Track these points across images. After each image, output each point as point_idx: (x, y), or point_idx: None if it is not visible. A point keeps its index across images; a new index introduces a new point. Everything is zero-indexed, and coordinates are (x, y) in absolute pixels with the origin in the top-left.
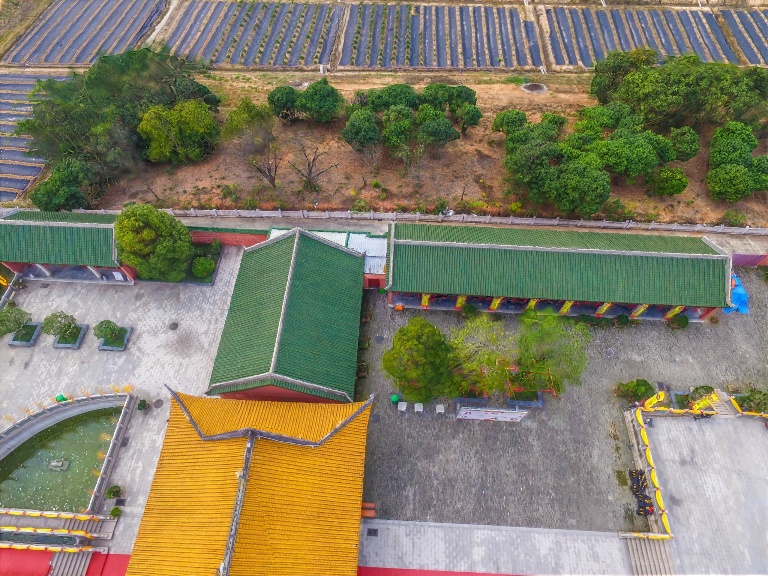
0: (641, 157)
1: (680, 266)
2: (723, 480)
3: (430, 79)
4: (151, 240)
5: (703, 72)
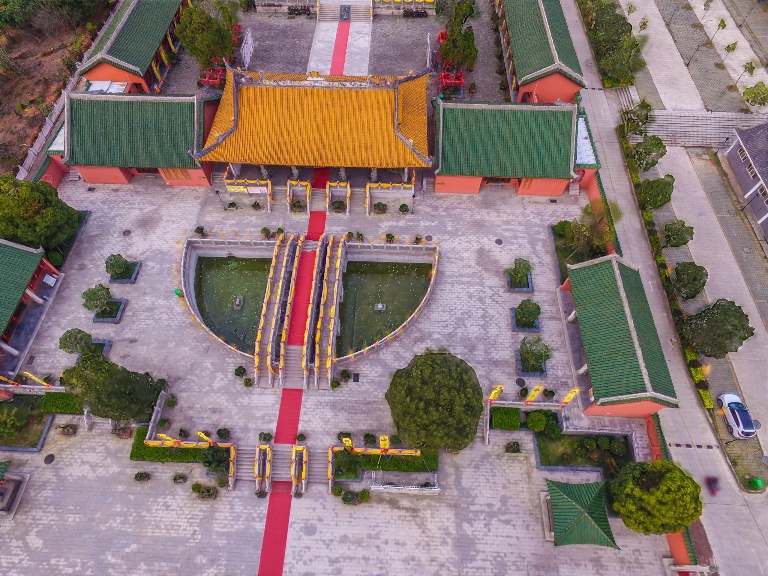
0: None
1: None
2: None
3: None
4: (32, 187)
5: None
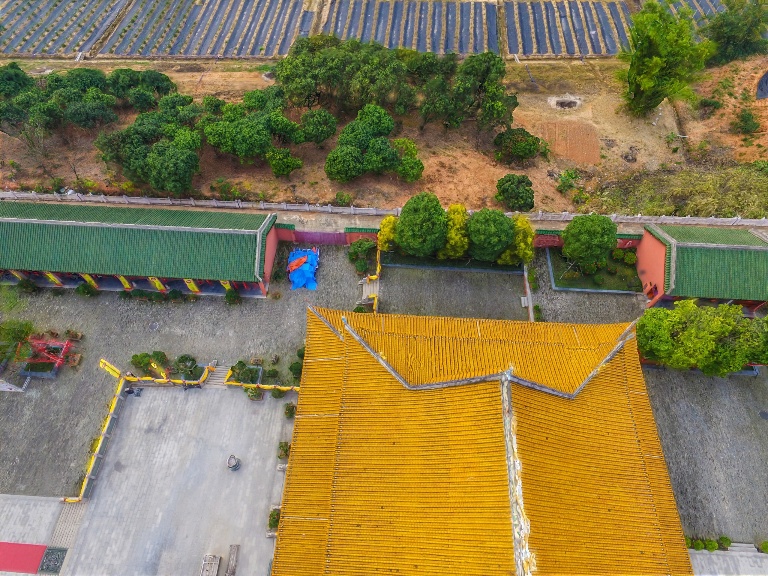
0: (246, 137)
1: (214, 241)
2: (179, 447)
3: (179, 67)
4: None
5: (352, 56)
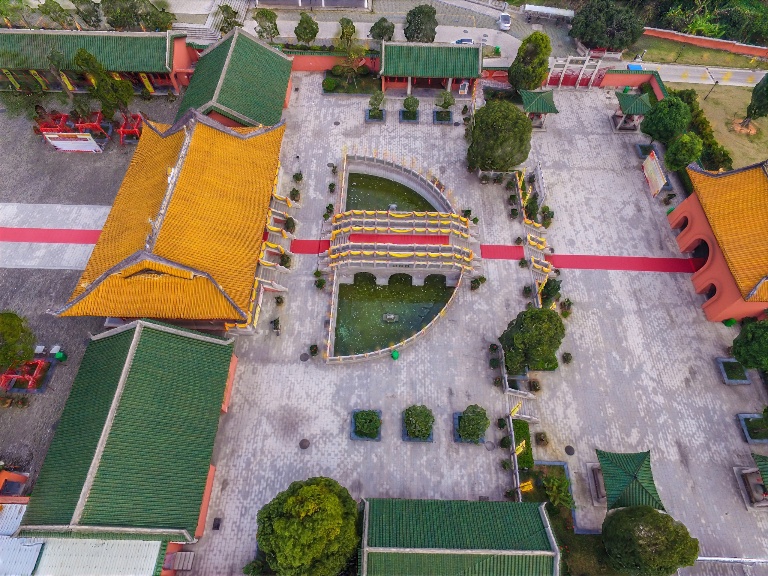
0: None
1: None
2: None
3: None
4: None
5: None
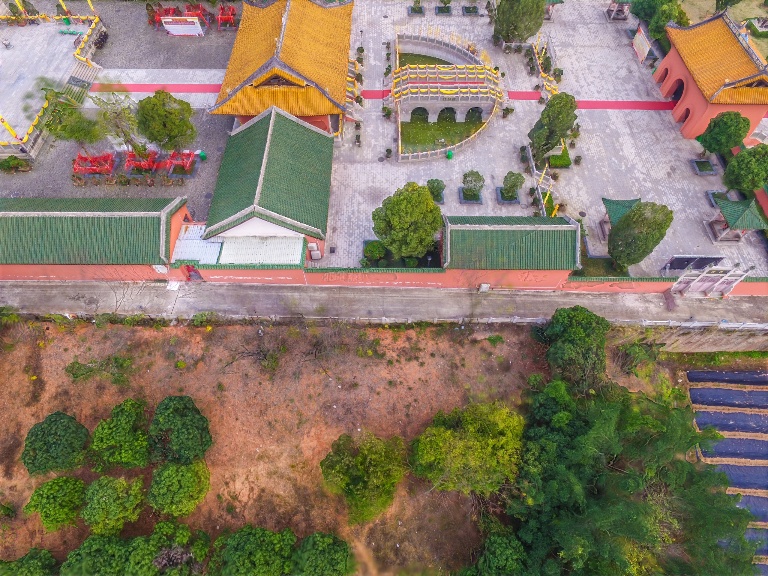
0: None
1: None
2: None
3: None
4: None
5: None
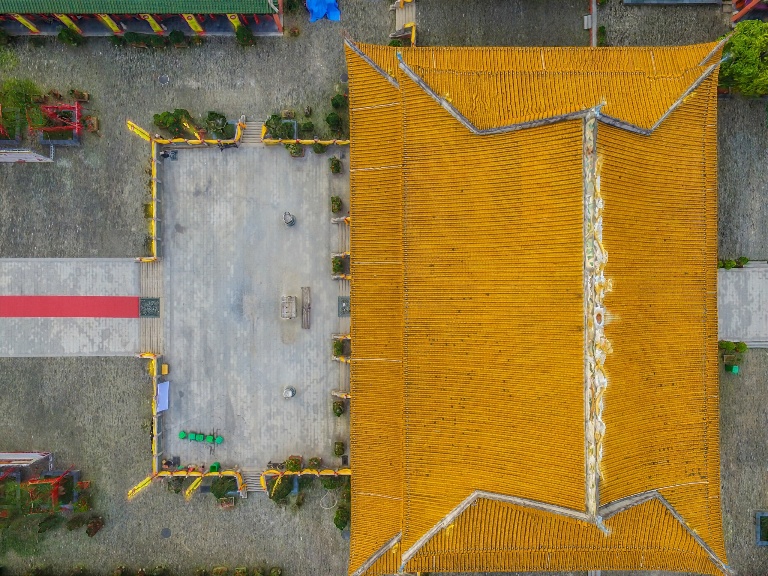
0: None
1: None
2: (231, 207)
3: None
4: None
5: None
